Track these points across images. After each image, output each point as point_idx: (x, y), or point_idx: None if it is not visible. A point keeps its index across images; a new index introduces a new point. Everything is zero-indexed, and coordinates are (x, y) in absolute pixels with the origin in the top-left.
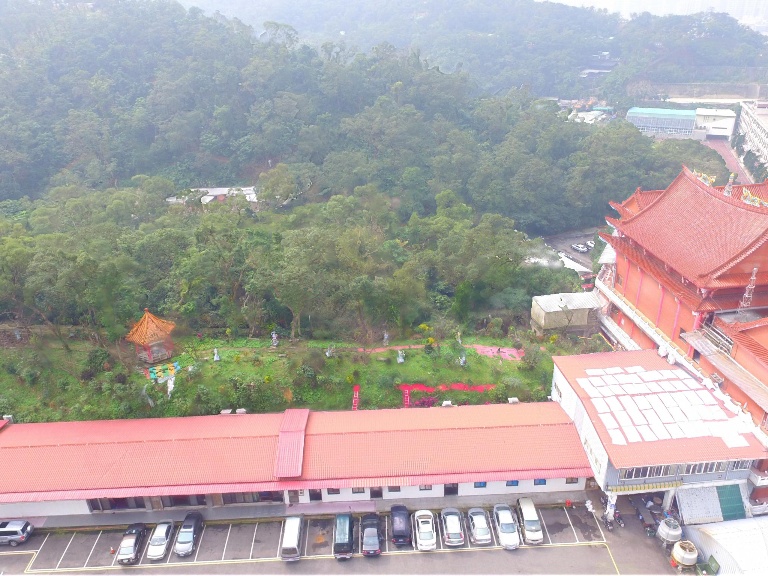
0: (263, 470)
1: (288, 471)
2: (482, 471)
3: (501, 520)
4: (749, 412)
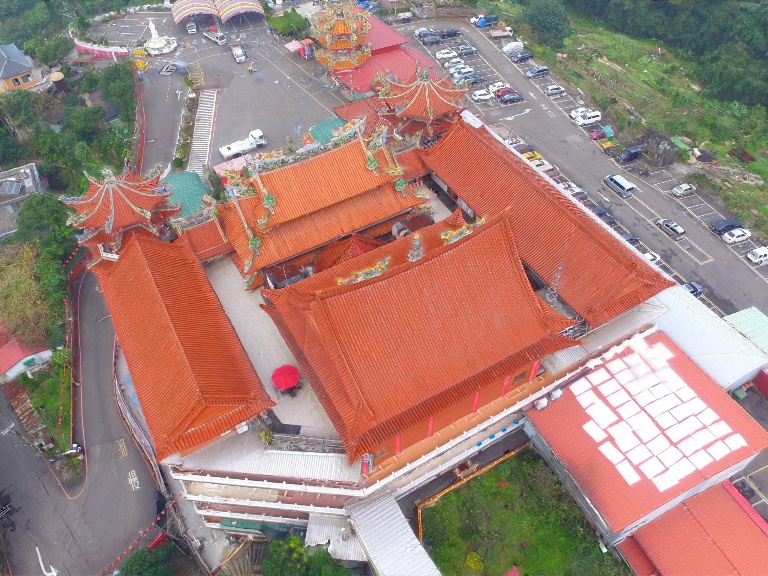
0: None
1: None
2: None
3: None
4: None
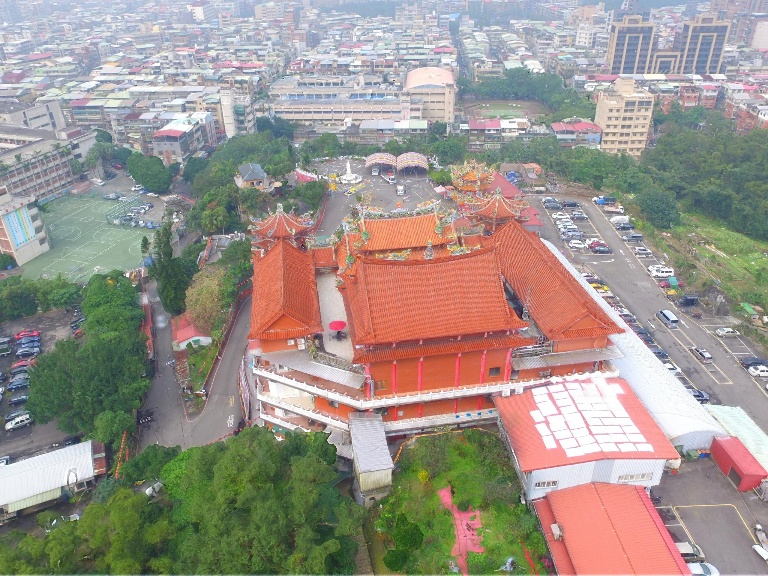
0: None
1: None
2: (680, 569)
3: (701, 573)
4: (580, 372)
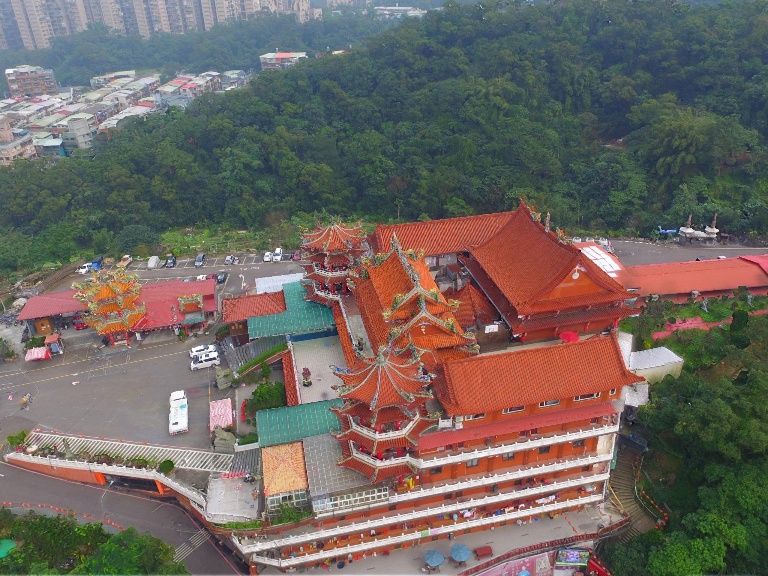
0: (761, 258)
1: (747, 256)
2: None
3: None
4: None
